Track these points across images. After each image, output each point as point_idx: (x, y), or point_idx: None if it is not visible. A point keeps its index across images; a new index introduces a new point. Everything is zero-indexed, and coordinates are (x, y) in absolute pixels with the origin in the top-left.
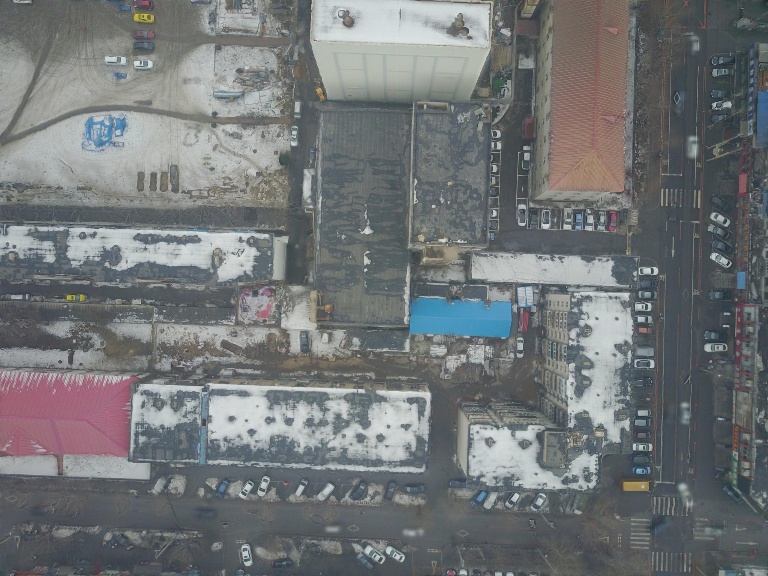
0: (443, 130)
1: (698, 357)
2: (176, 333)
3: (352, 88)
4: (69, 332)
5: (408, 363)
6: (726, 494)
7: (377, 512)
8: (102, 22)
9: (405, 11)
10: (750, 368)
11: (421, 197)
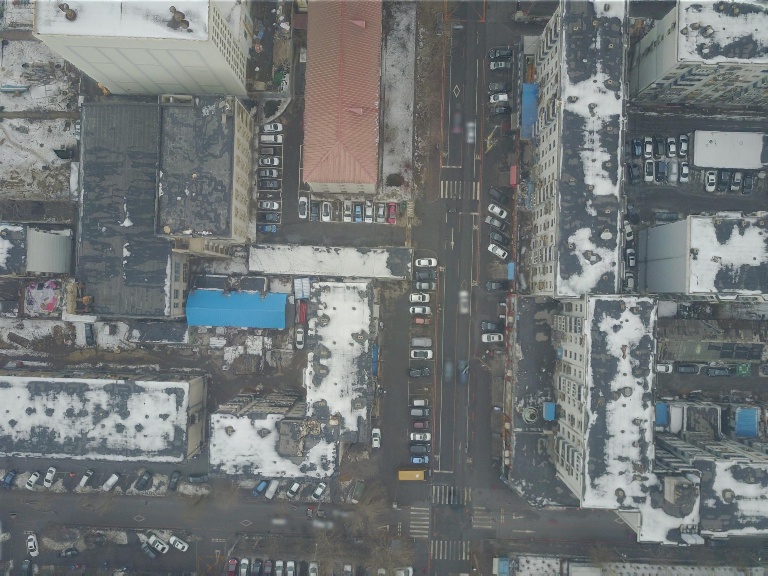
0: (188, 123)
1: (476, 347)
2: None
3: (122, 82)
4: None
5: (192, 355)
6: (502, 483)
7: (162, 502)
8: None
9: (126, 4)
10: (512, 357)
11: (167, 189)
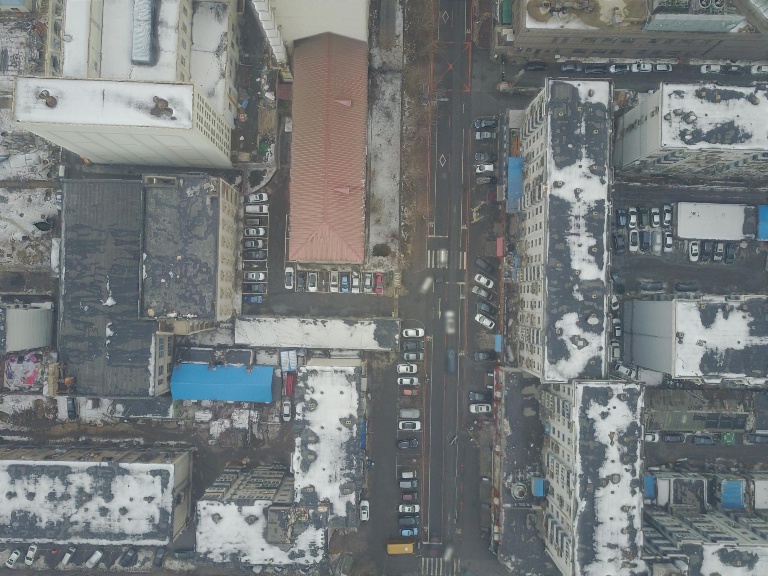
0: (172, 204)
1: (464, 418)
2: None
3: (105, 155)
4: None
5: (177, 428)
6: (491, 554)
7: None
8: None
9: (108, 92)
10: (500, 432)
11: (151, 271)
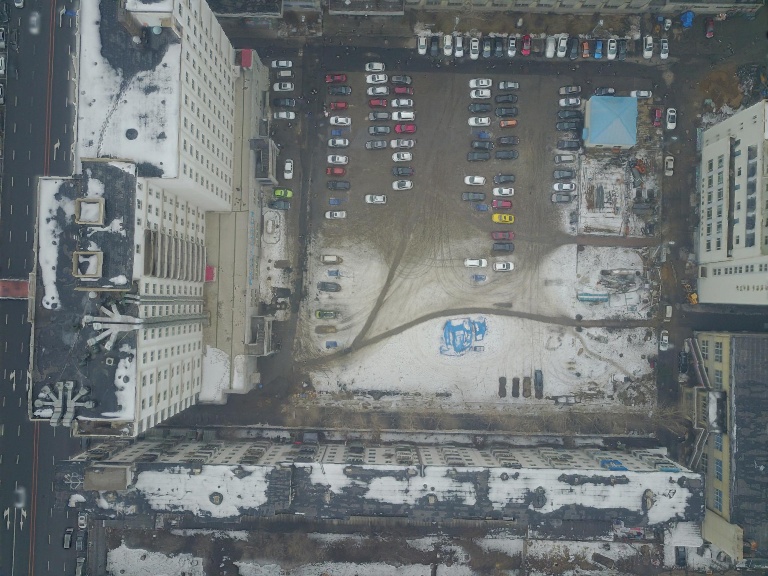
0: None
1: None
2: (545, 546)
3: None
4: (431, 545)
5: None
6: None
7: None
8: (458, 222)
9: None
10: None
11: None
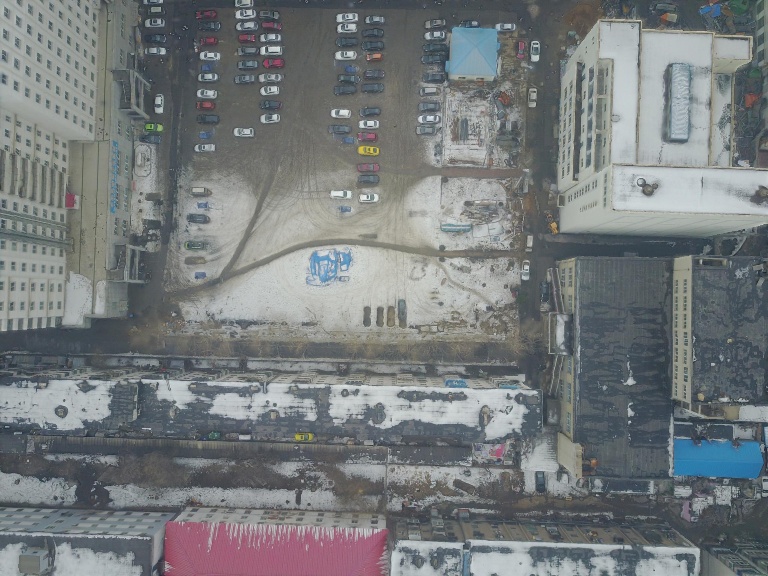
0: (721, 286)
1: None
2: (407, 472)
3: (599, 229)
4: (296, 471)
5: (647, 502)
6: None
7: None
8: (325, 154)
9: (707, 179)
10: None
11: (700, 355)
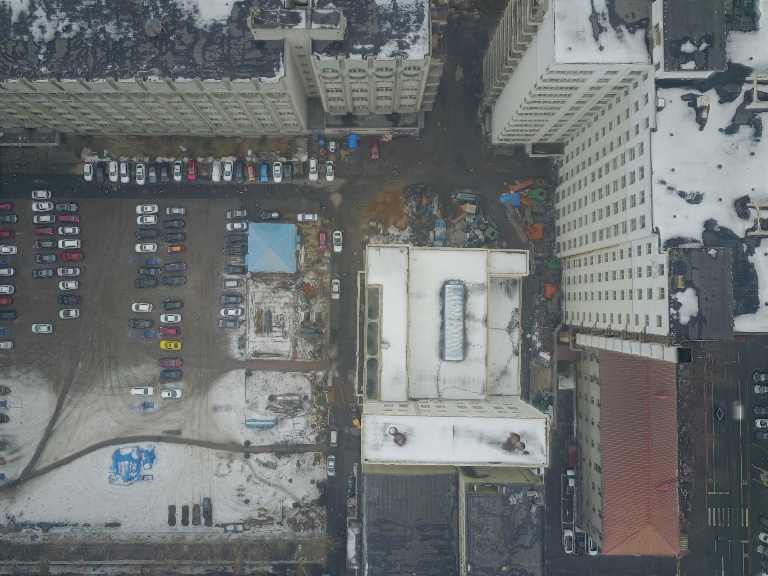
0: (495, 512)
1: None
2: None
3: None
4: None
5: None
6: None
7: None
8: (127, 349)
9: (458, 427)
10: None
11: None
